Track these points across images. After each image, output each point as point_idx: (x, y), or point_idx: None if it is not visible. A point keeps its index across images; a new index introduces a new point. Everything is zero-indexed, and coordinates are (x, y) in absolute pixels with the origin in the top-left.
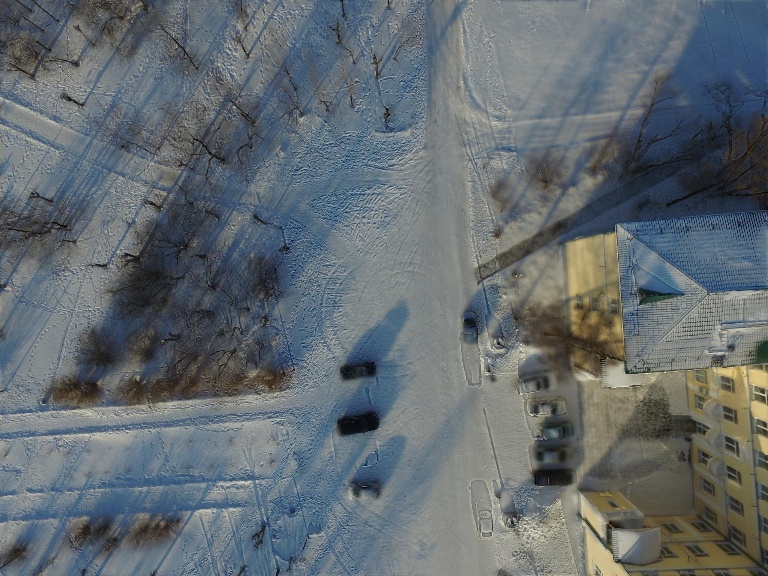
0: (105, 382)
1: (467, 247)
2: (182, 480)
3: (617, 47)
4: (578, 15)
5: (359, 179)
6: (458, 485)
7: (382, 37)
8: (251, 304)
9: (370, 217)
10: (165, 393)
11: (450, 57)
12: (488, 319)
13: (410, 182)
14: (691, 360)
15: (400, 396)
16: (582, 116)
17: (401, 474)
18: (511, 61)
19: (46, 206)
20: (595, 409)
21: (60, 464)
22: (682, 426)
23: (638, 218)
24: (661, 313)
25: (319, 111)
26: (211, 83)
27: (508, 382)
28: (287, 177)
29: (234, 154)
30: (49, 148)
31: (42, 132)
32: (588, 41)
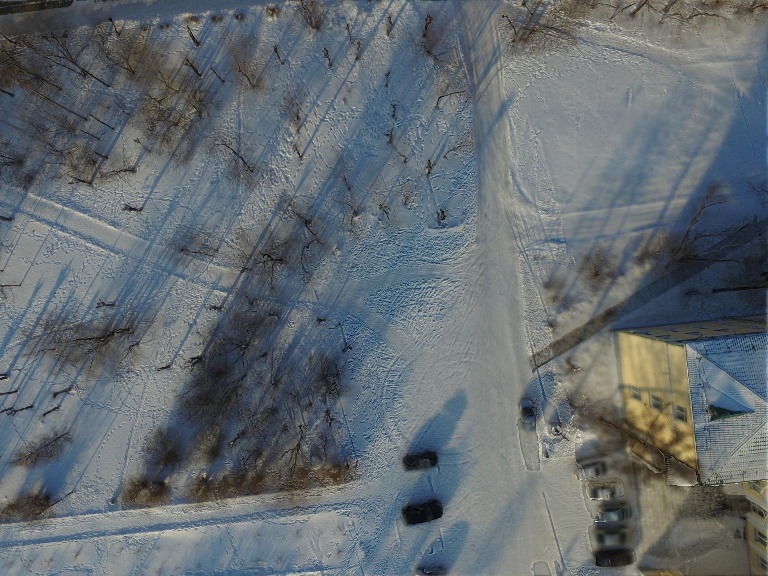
0: (172, 480)
1: (521, 336)
2: (251, 573)
3: (659, 140)
4: (621, 110)
5: (414, 274)
6: (521, 567)
7: (432, 136)
8: (313, 399)
9: (426, 310)
10: (232, 489)
11: (498, 153)
12: (544, 406)
13: (463, 275)
14: (762, 472)
15: (461, 483)
16: (628, 207)
17: (465, 558)
18: (557, 156)
19: (108, 310)
20: (652, 490)
21: (131, 562)
22: (737, 505)
23: (687, 306)
24: (732, 429)
25: (373, 209)
26: (266, 185)
27: (566, 466)
28: (344, 274)
29: (291, 254)
30: (109, 253)
31: (101, 238)
32: (631, 135)
